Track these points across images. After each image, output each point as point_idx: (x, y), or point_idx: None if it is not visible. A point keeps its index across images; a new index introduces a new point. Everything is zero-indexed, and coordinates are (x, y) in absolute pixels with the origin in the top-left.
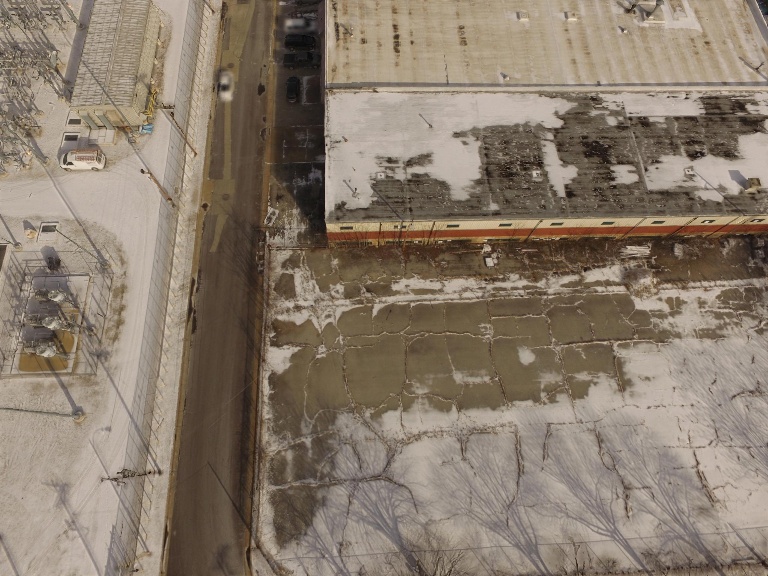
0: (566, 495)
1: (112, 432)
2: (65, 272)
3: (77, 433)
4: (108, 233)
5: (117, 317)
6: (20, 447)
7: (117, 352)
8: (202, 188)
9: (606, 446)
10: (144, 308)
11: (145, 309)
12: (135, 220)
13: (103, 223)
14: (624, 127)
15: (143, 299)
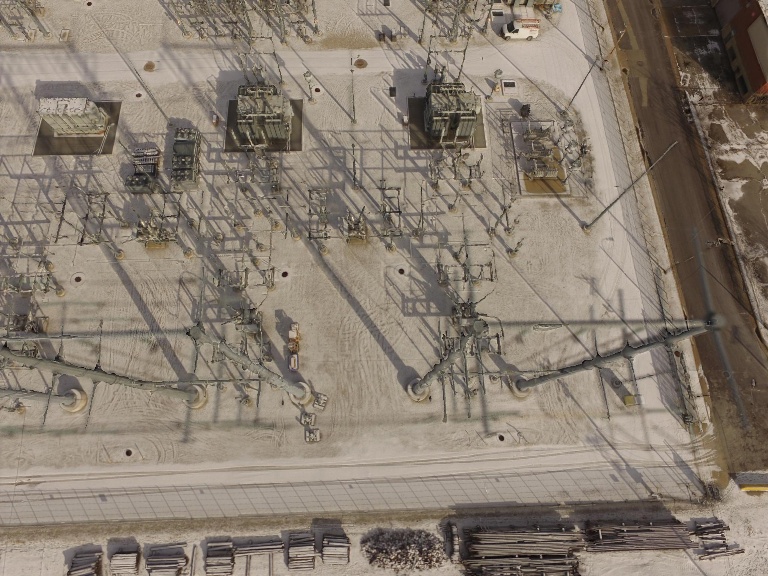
0: None
1: (615, 241)
2: (534, 119)
3: (589, 241)
4: (556, 89)
5: (588, 155)
6: (548, 250)
7: (597, 181)
8: (617, 56)
9: None
10: (607, 148)
11: (608, 149)
12: (575, 80)
13: (550, 81)
14: None
15: (603, 141)
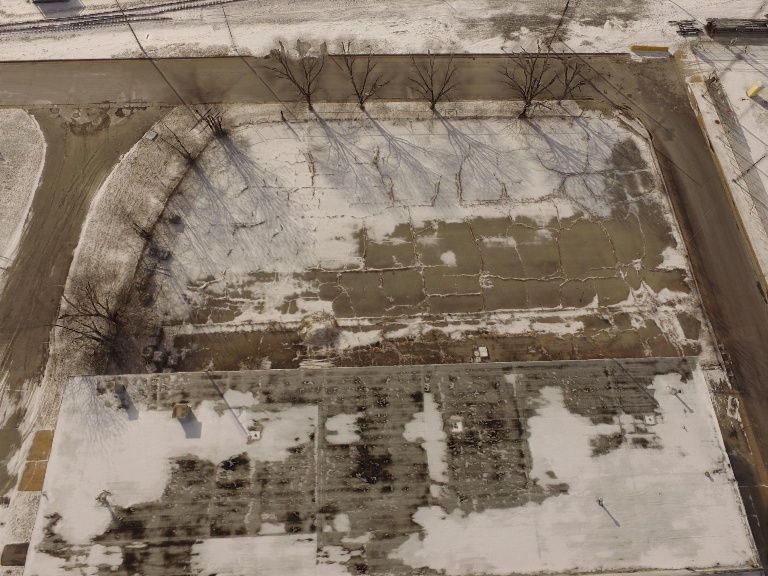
0: (424, 161)
1: None
2: None
3: None
4: None
5: None
6: None
7: None
8: None
9: (387, 190)
10: None
11: None
12: None
13: None
14: (326, 511)
15: None
